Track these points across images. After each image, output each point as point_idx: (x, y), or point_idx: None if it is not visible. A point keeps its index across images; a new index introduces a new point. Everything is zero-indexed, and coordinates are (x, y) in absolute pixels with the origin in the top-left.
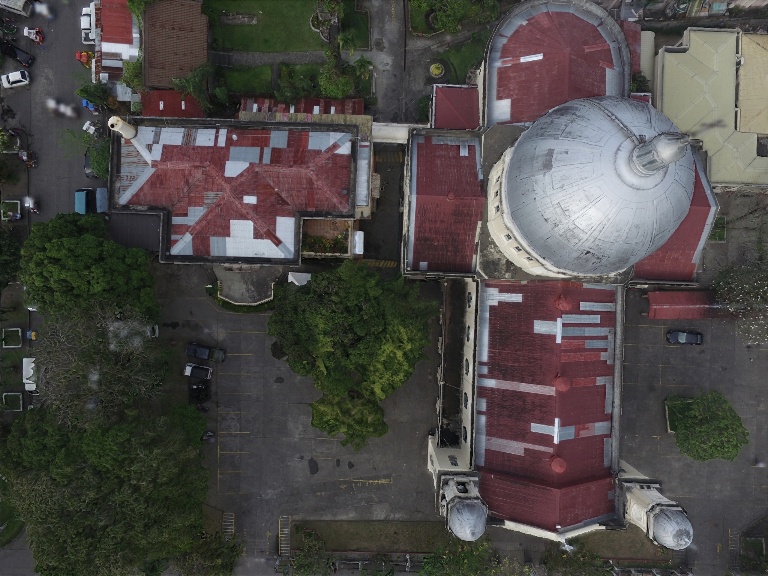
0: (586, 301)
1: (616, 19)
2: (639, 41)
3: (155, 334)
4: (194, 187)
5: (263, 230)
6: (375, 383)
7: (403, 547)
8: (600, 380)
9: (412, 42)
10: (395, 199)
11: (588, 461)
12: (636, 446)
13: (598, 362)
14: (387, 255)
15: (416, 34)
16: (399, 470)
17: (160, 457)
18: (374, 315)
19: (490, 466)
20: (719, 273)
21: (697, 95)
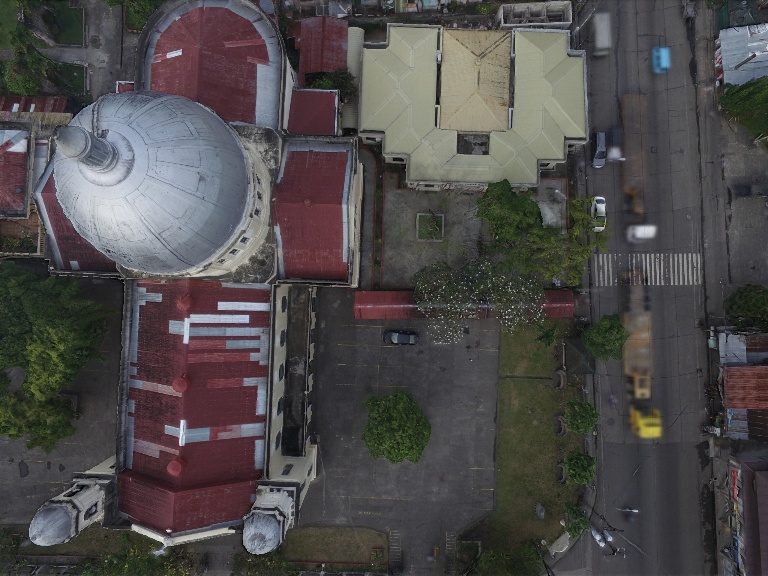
0: (227, 301)
1: (324, 15)
2: (346, 37)
3: None
4: None
5: None
6: (31, 384)
7: (114, 551)
8: (250, 381)
9: (129, 39)
10: None
11: (231, 464)
12: (352, 448)
13: (246, 363)
14: None
15: (131, 31)
16: None
17: None
18: (12, 315)
19: (136, 469)
20: (416, 272)
21: (390, 92)
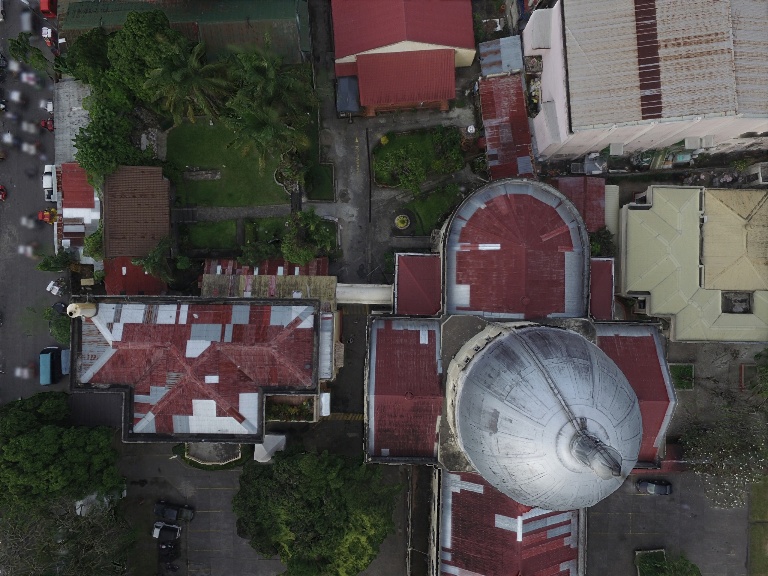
0: None
1: (580, 172)
2: (603, 195)
3: (123, 495)
4: (156, 366)
5: (226, 408)
6: (339, 567)
7: None
8: (563, 566)
9: (377, 193)
10: (362, 352)
11: None
12: None
13: (561, 548)
14: (355, 408)
15: (381, 186)
16: None
17: None
18: (335, 509)
19: None
20: (685, 432)
21: (660, 256)
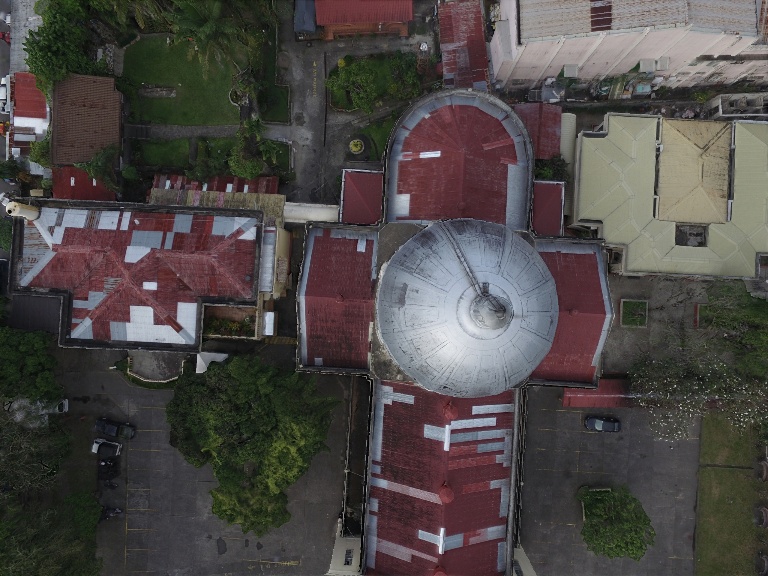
0: (480, 404)
1: (537, 100)
2: (559, 123)
3: (64, 409)
4: (95, 271)
5: (163, 316)
6: (269, 478)
7: None
8: (495, 484)
9: (333, 117)
10: None
11: (479, 568)
12: (551, 534)
13: (493, 465)
14: None
15: (336, 109)
16: (308, 552)
17: (41, 555)
18: (263, 414)
19: (380, 569)
20: (633, 364)
21: (613, 183)
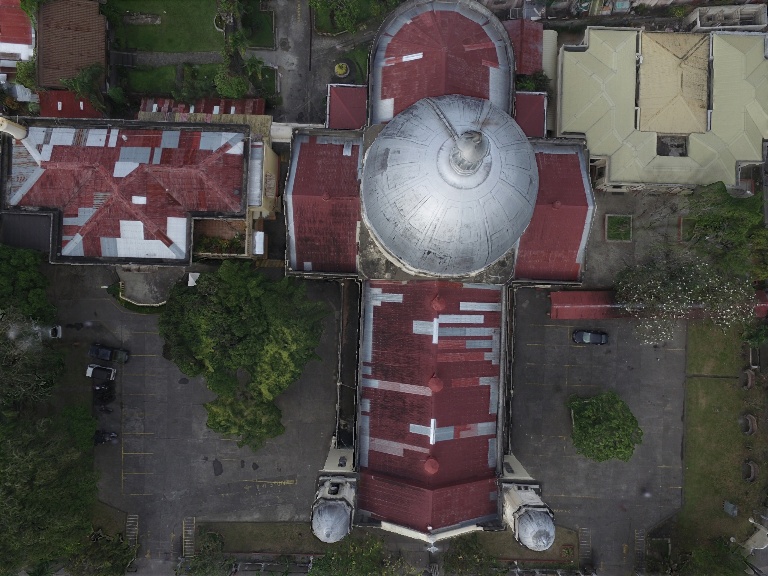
0: (467, 301)
1: (518, 18)
2: (541, 40)
3: (57, 335)
4: (84, 188)
5: (153, 231)
6: (261, 384)
7: (308, 548)
8: (484, 380)
9: (317, 42)
10: None
11: (470, 462)
12: (542, 446)
13: (481, 362)
14: None
15: (321, 34)
16: (304, 471)
17: (37, 459)
18: (254, 316)
19: (373, 467)
20: (618, 273)
21: (595, 94)
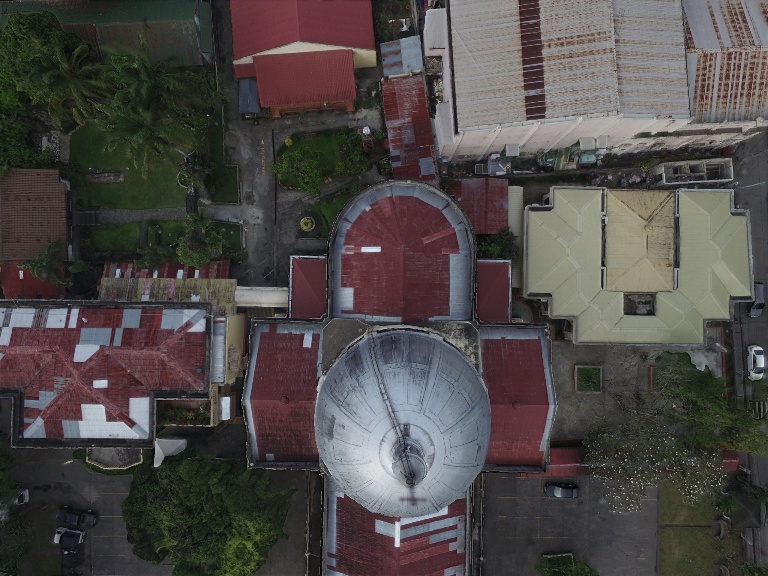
0: None
1: (483, 173)
2: (506, 196)
3: (24, 500)
4: (45, 371)
5: (115, 413)
6: (226, 573)
7: None
8: (449, 571)
9: (283, 195)
10: None
11: None
12: None
13: (446, 554)
14: None
15: (286, 188)
16: None
17: None
18: (215, 515)
19: None
20: (587, 435)
21: (560, 258)
